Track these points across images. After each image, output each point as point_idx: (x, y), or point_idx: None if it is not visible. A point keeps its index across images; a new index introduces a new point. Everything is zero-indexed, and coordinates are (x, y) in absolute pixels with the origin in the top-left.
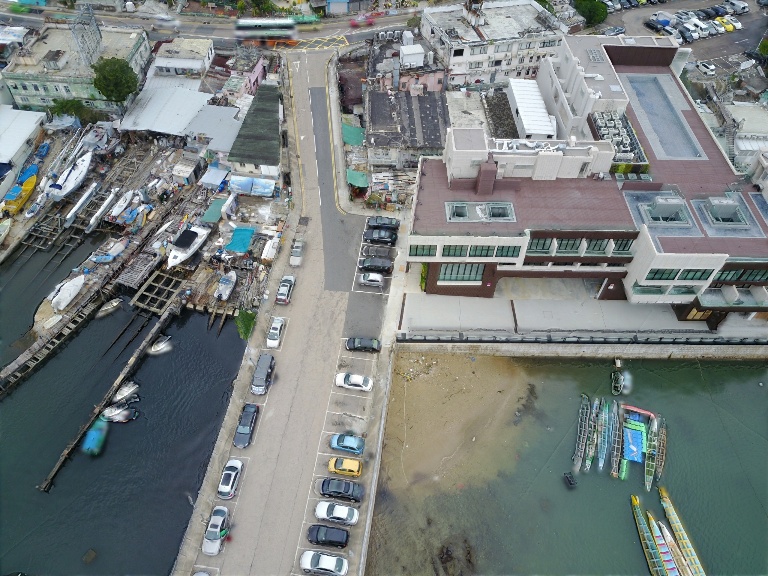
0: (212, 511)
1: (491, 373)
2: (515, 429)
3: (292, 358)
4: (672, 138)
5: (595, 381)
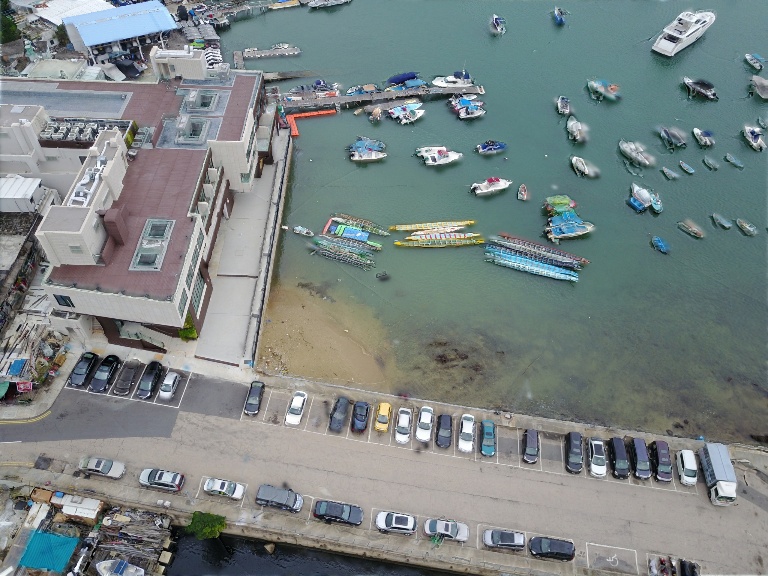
0: (431, 535)
1: (284, 310)
2: (338, 302)
3: (259, 471)
4: (89, 106)
5: (300, 244)
